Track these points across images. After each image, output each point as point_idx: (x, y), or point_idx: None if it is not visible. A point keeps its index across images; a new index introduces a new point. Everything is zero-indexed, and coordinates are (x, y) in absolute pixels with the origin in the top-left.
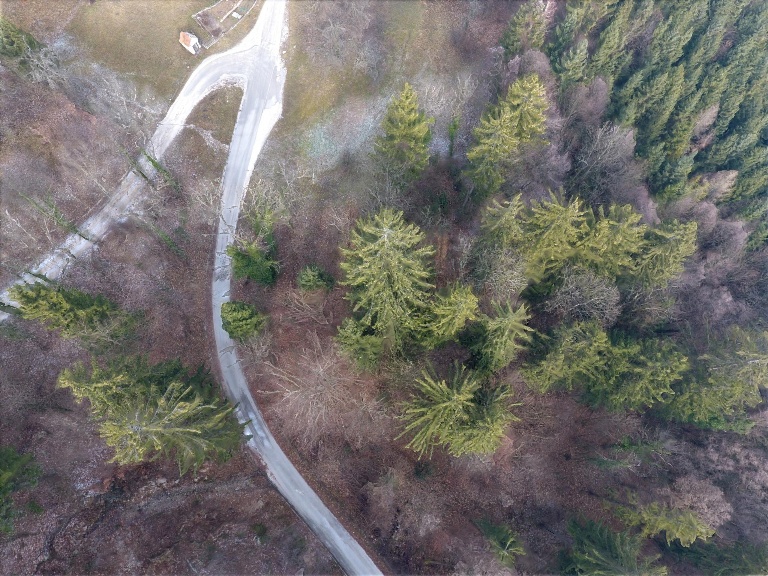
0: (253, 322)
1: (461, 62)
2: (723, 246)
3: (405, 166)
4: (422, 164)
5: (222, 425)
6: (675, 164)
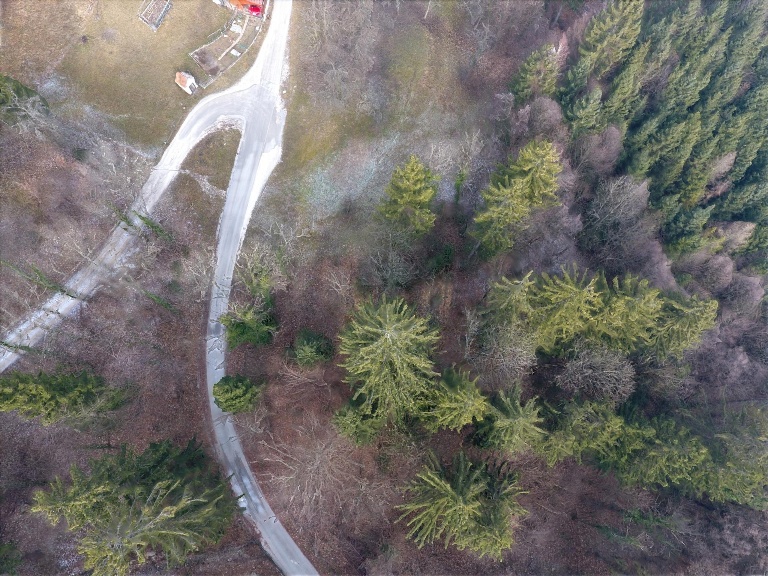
0: (247, 398)
1: (468, 99)
2: (739, 302)
3: (409, 230)
4: (427, 225)
5: (213, 512)
6: (690, 215)
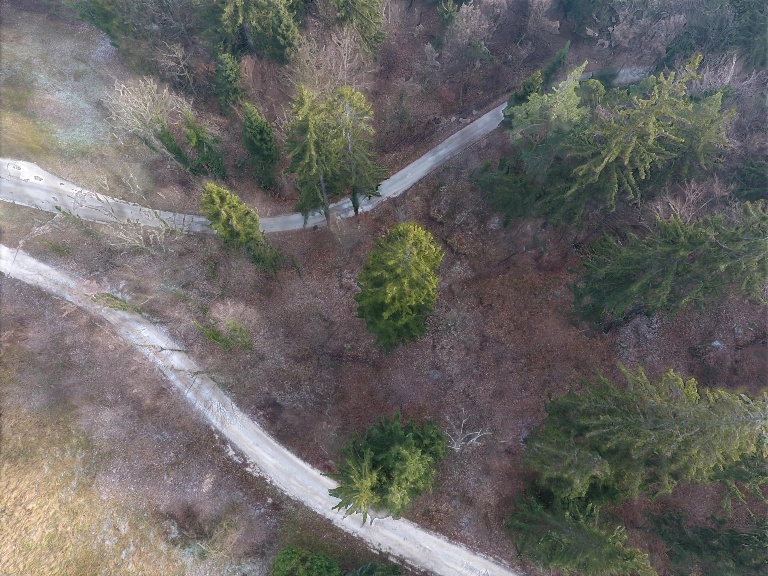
0: None
1: (11, 28)
2: None
3: None
4: None
5: None
6: None
